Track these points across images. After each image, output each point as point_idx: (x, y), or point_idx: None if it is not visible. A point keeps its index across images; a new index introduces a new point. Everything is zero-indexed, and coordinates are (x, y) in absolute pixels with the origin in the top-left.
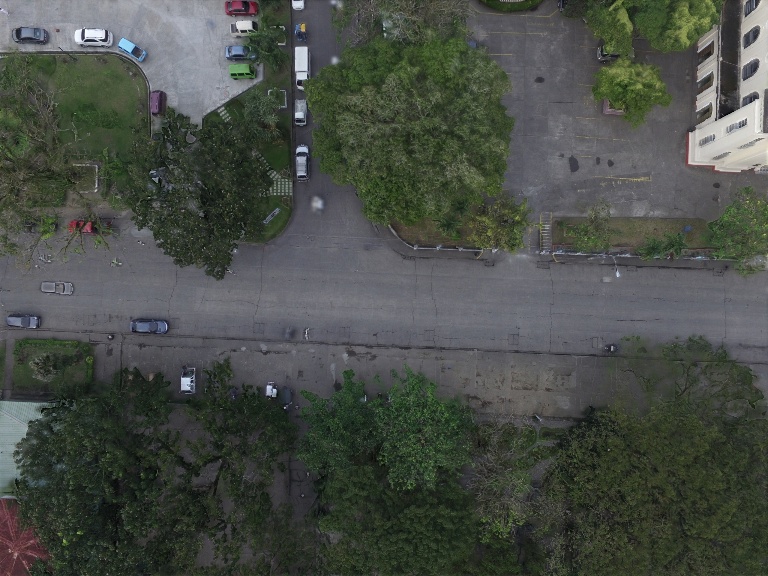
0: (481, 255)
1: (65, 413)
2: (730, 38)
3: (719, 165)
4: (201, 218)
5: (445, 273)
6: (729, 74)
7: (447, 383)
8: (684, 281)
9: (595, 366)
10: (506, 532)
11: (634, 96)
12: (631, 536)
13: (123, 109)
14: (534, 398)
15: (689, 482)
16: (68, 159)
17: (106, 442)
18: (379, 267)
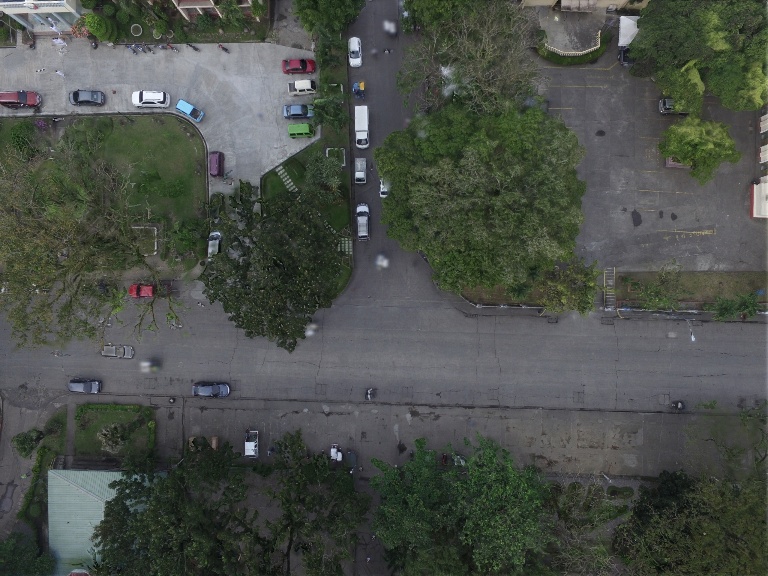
0: (544, 312)
1: (138, 489)
2: None
3: None
4: None
5: (508, 331)
6: None
7: (512, 442)
8: (751, 335)
9: (662, 423)
10: None
11: (704, 155)
12: None
13: (181, 170)
14: (601, 456)
15: None
16: (127, 222)
17: (191, 529)
18: (441, 326)
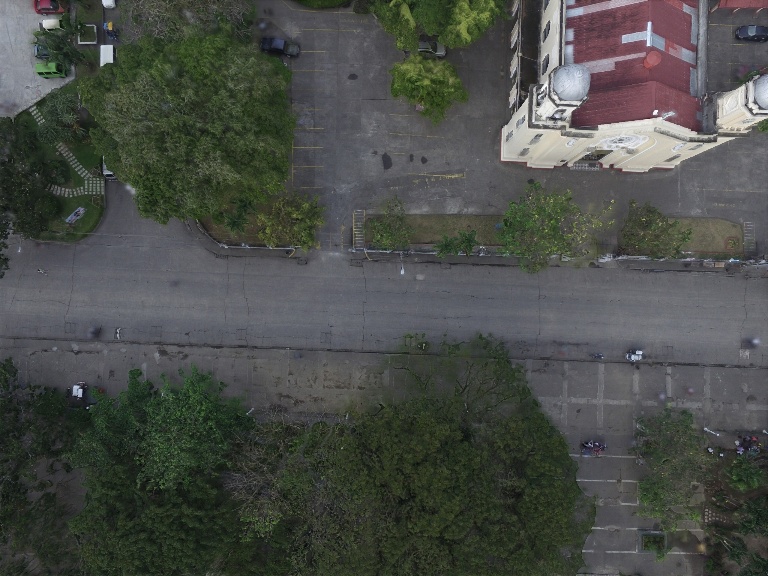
0: (294, 253)
1: None
2: (530, 33)
3: (529, 161)
4: None
5: (257, 272)
6: (529, 70)
7: (259, 382)
8: (498, 278)
9: (408, 364)
10: (263, 531)
11: (426, 92)
12: (357, 535)
13: None
14: (347, 397)
15: (418, 480)
16: None
17: None
18: (191, 266)
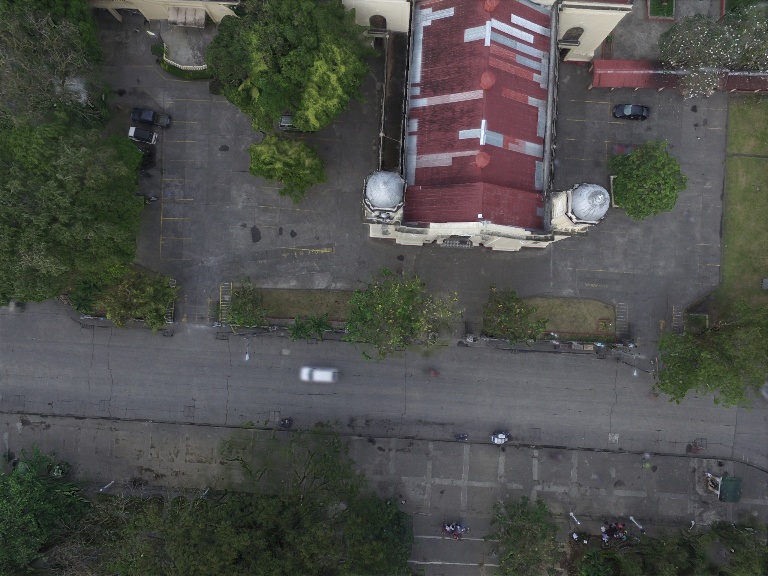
0: None
1: None
2: (394, 113)
3: None
4: None
5: (123, 343)
6: (391, 150)
7: (121, 454)
8: None
9: (271, 440)
10: None
11: (280, 174)
12: None
13: None
14: (208, 471)
15: None
16: None
17: None
18: (56, 335)
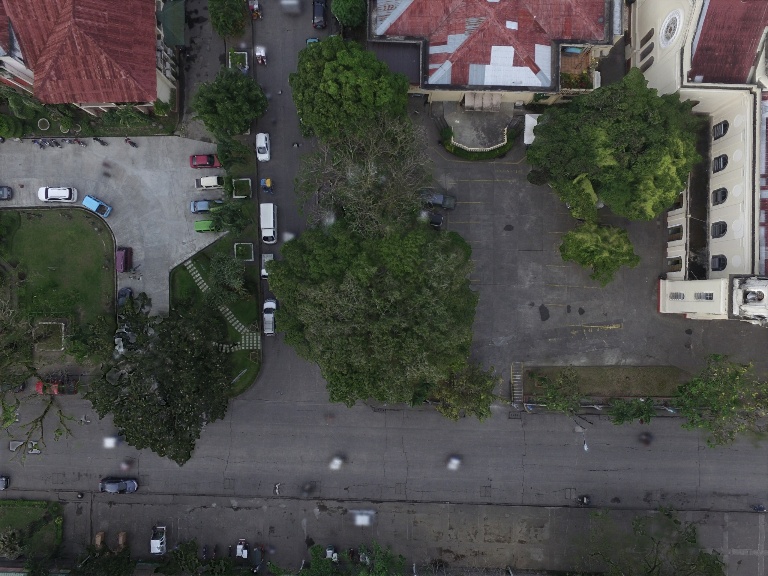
0: None
1: None
2: (699, 194)
3: (690, 315)
4: (163, 406)
5: (416, 425)
6: (698, 231)
7: (419, 537)
8: (657, 429)
9: (568, 517)
10: None
11: None
12: None
13: (89, 264)
14: (507, 550)
15: None
16: (34, 317)
17: None
18: (349, 420)
